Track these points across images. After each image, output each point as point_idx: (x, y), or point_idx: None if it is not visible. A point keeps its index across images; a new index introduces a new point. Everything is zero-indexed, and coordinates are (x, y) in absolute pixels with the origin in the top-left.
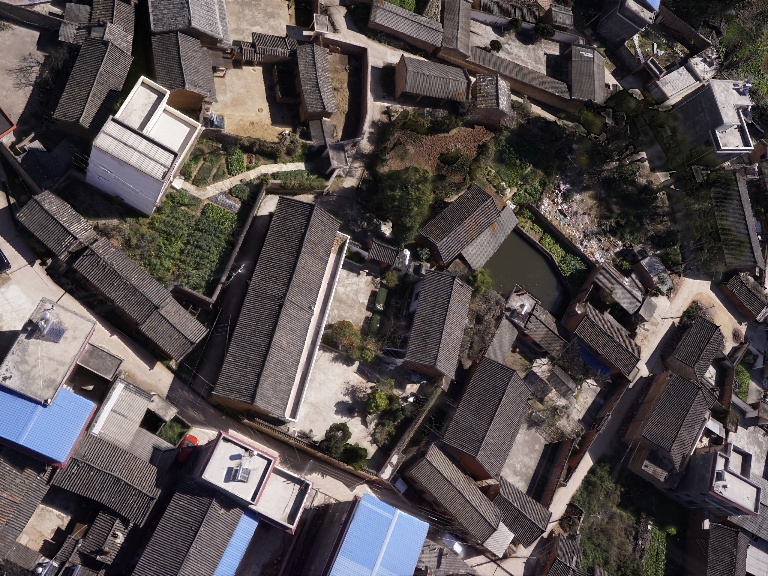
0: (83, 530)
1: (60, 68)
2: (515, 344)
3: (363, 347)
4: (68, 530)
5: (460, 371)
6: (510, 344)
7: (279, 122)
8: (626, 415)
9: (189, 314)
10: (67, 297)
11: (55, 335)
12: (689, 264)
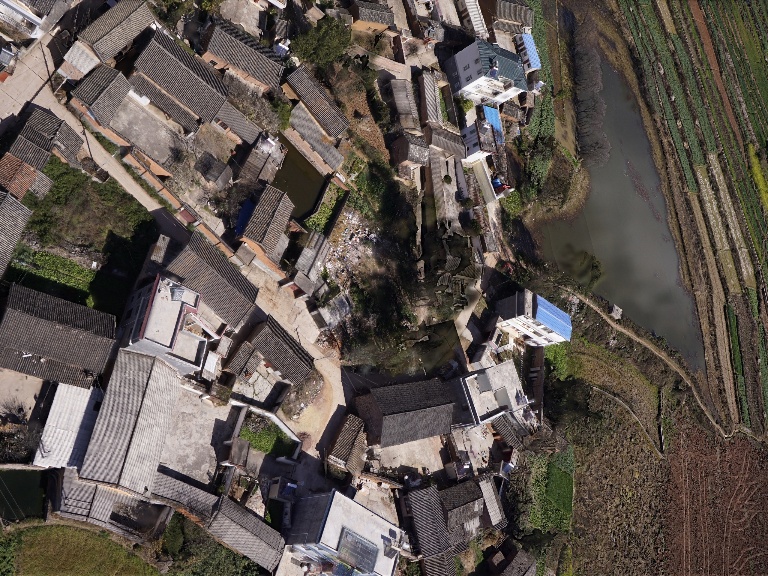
0: None
1: None
2: (238, 155)
3: (212, 1)
4: None
5: None
6: (240, 133)
7: None
8: None
9: None
10: None
11: None
12: None
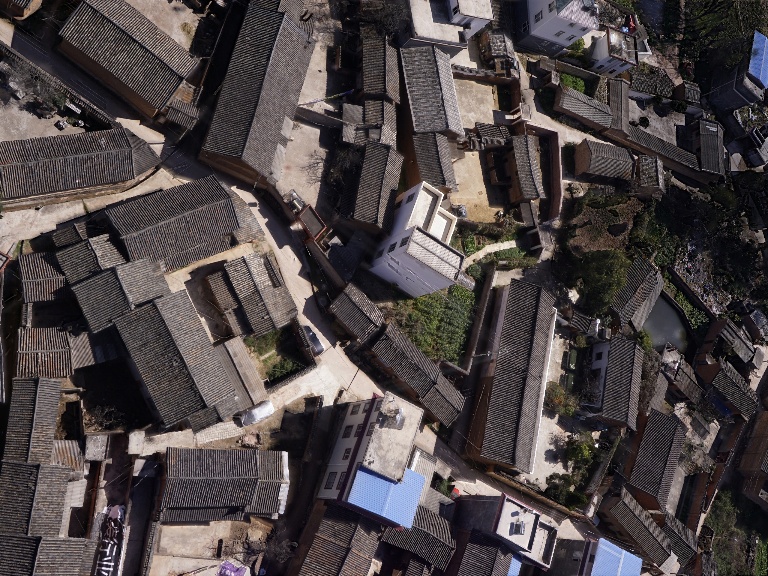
0: (399, 575)
1: (348, 168)
2: None
3: (567, 404)
4: (382, 574)
5: None
6: (664, 394)
7: (494, 203)
8: (739, 448)
9: (451, 385)
10: (360, 373)
11: (401, 424)
12: None
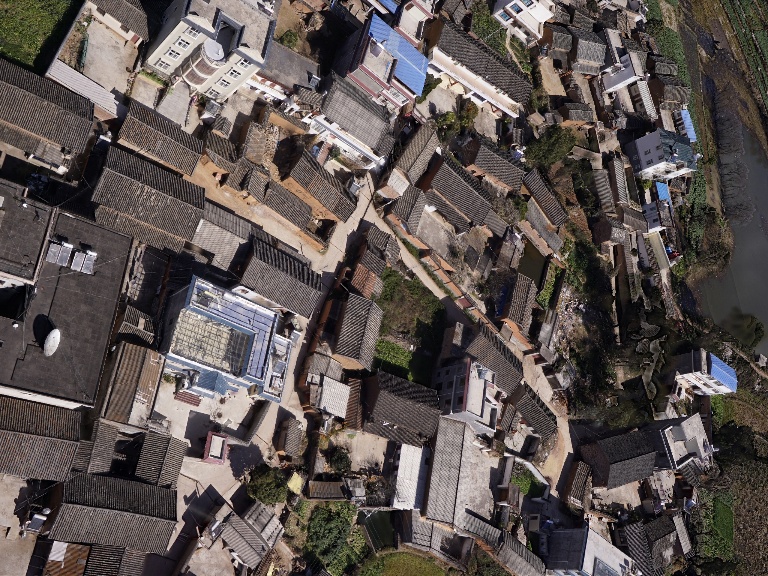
0: None
1: None
2: (490, 246)
3: (469, 119)
4: None
5: None
6: (494, 229)
7: None
8: None
9: None
10: None
11: None
12: (577, 429)
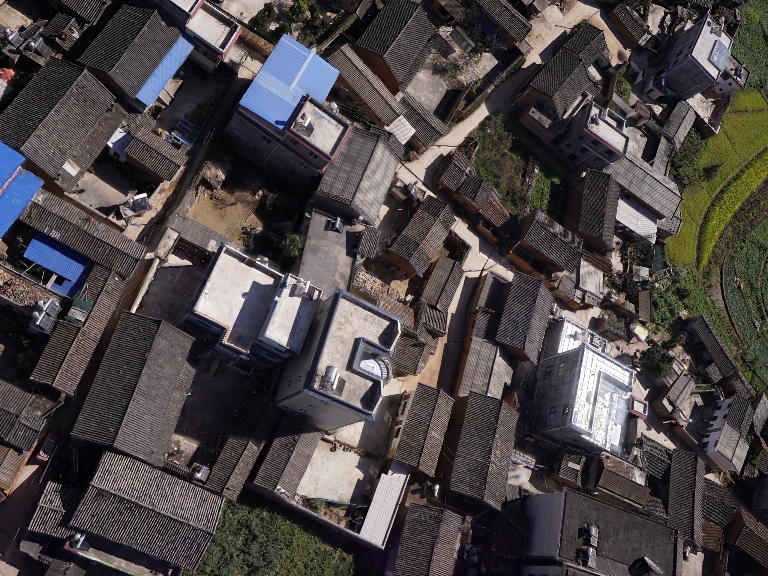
0: (44, 23)
1: None
2: (424, 10)
3: None
4: None
5: (374, 8)
6: (418, 1)
7: None
8: (520, 86)
9: None
10: None
11: None
12: None
